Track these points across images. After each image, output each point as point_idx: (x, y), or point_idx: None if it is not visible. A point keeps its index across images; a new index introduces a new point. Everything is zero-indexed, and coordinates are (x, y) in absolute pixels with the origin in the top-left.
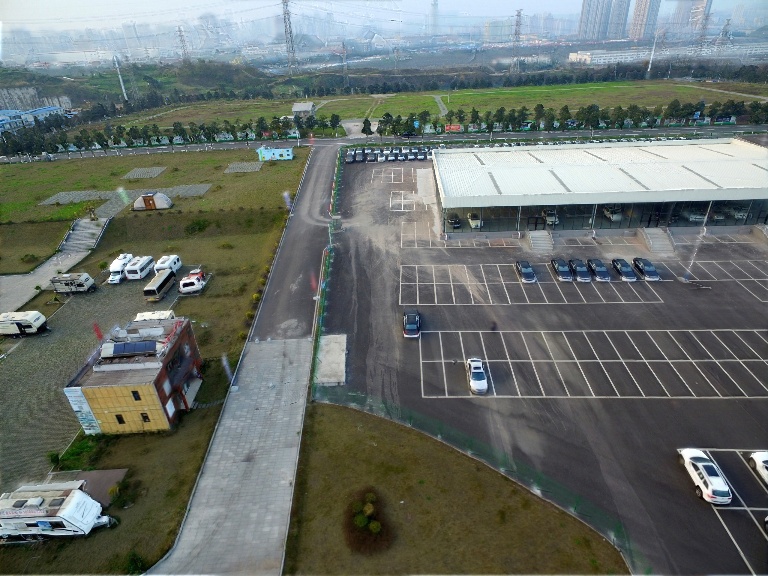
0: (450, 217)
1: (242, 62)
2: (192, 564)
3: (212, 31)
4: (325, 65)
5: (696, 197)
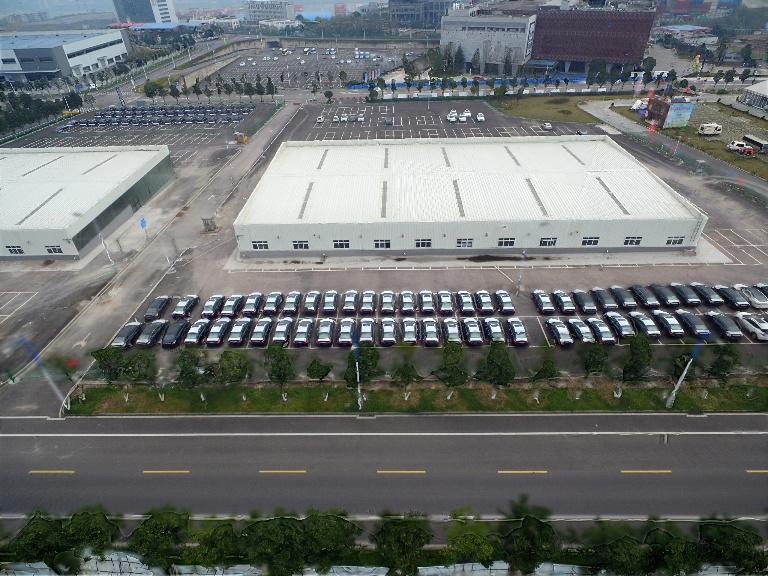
0: None
1: None
2: None
3: None
4: None
5: None
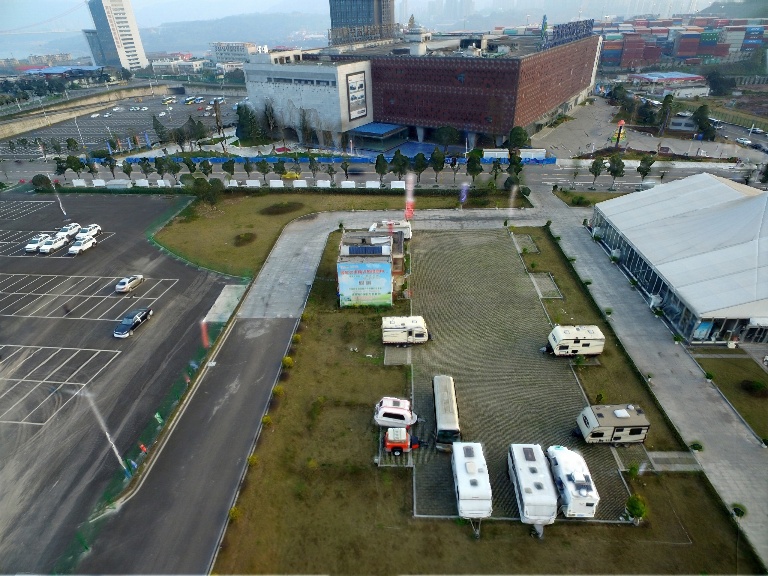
0: None
1: None
2: (320, 231)
3: None
4: None
5: None
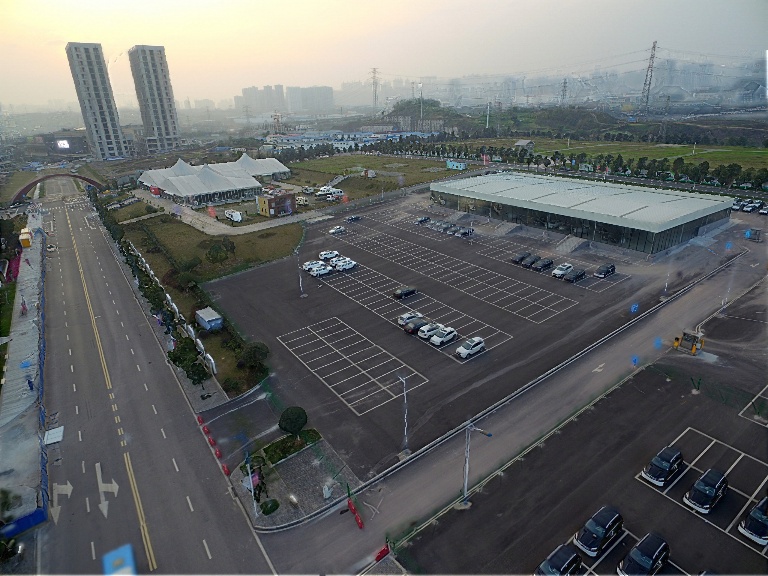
0: (433, 196)
1: (603, 109)
2: None
3: (586, 83)
4: (695, 115)
5: (539, 208)
